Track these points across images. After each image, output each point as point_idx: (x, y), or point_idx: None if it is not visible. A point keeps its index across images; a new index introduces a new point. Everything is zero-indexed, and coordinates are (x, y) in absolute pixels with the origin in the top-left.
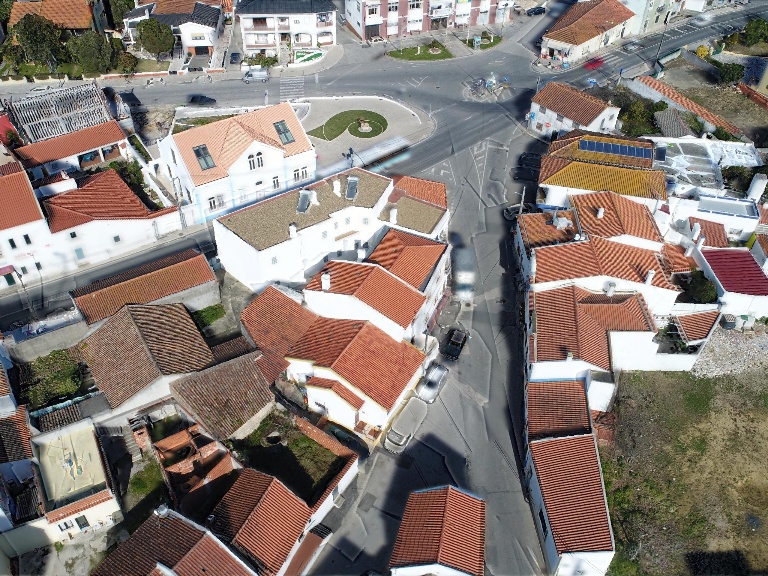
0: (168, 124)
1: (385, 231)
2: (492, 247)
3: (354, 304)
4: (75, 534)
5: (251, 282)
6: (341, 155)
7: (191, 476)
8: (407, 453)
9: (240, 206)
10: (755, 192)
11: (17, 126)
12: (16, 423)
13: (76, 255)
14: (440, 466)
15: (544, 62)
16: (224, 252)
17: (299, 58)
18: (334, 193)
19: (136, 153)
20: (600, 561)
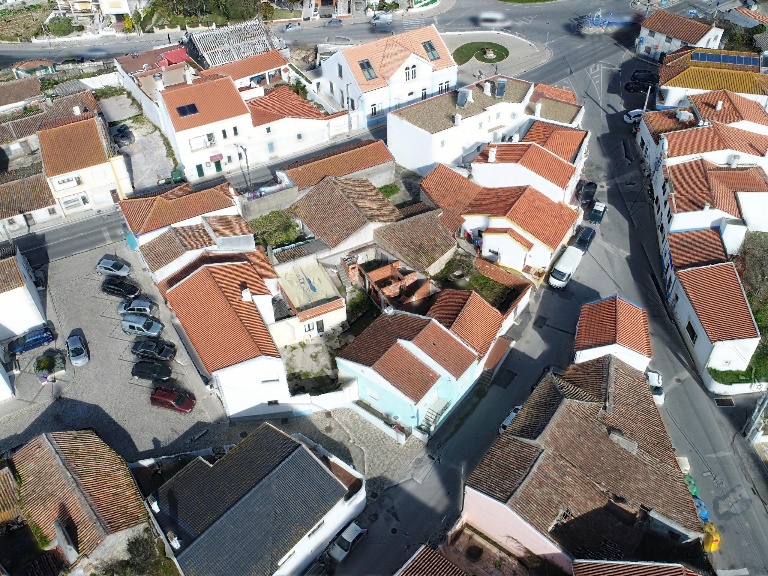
0: (312, 58)
1: (531, 123)
2: (617, 144)
3: (518, 171)
4: (313, 337)
5: (419, 166)
6: (472, 76)
7: (399, 298)
8: (567, 289)
9: None
10: None
11: (196, 55)
12: (259, 256)
13: (268, 149)
14: (596, 298)
15: (642, 1)
16: (394, 142)
17: (417, 4)
18: (484, 94)
19: (298, 75)
20: (746, 349)
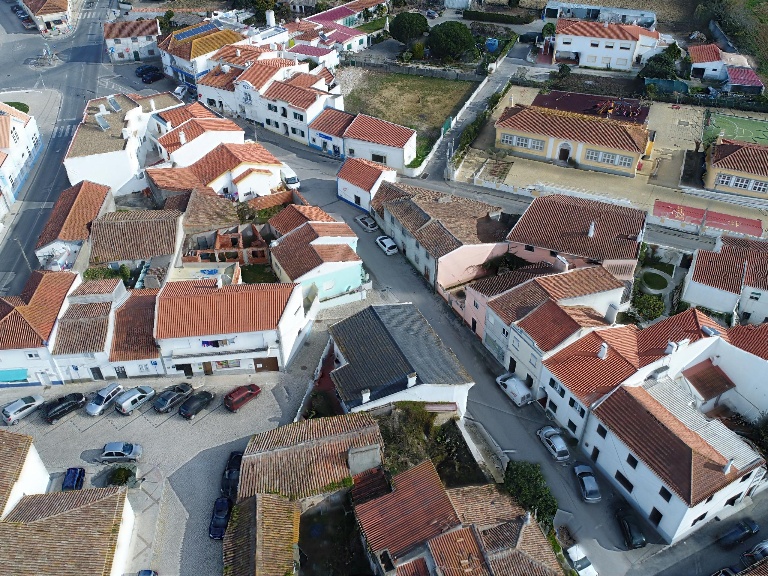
0: None
1: None
2: None
3: (210, 137)
4: None
5: (119, 188)
6: None
7: None
8: (301, 187)
9: (23, 180)
10: (272, 21)
11: None
12: None
13: None
14: (318, 181)
15: None
16: None
17: None
18: (103, 115)
19: None
20: None
